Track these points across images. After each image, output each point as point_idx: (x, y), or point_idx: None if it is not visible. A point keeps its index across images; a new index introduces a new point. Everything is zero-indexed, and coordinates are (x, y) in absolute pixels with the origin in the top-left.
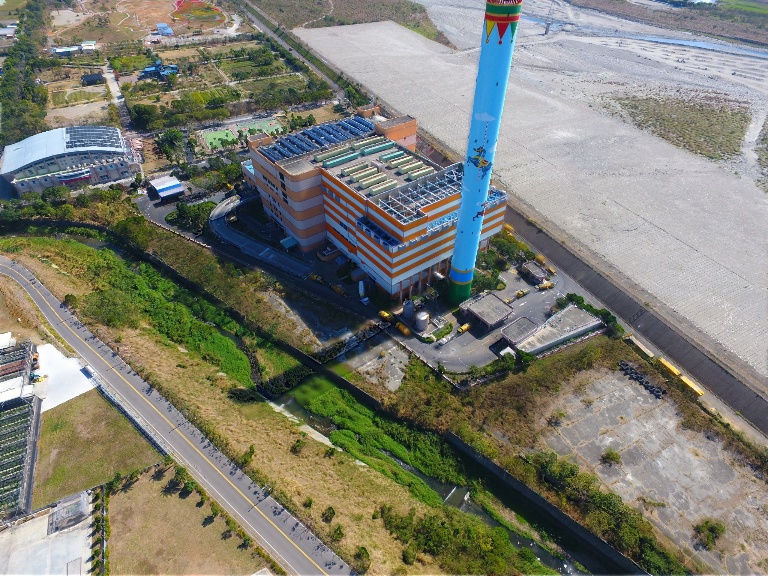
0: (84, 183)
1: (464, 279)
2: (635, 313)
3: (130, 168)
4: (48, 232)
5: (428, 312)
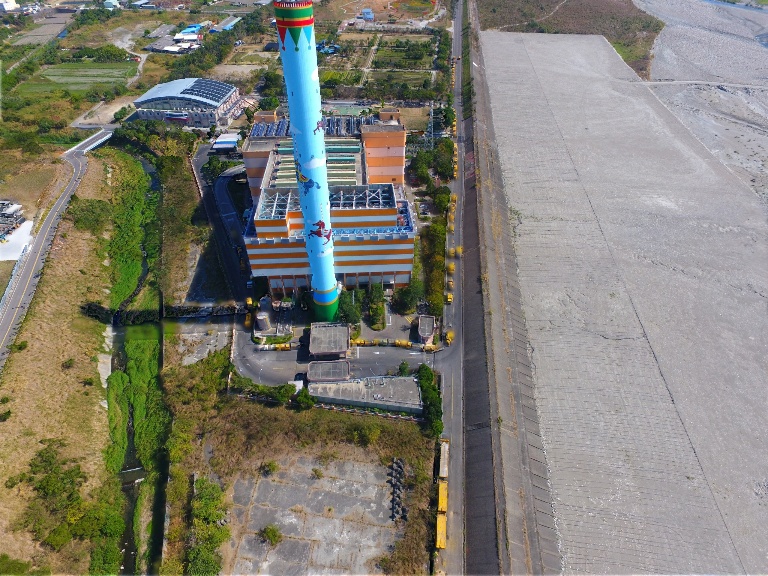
0: (183, 123)
1: (319, 299)
2: (479, 422)
3: (220, 120)
4: (135, 152)
5: (284, 317)
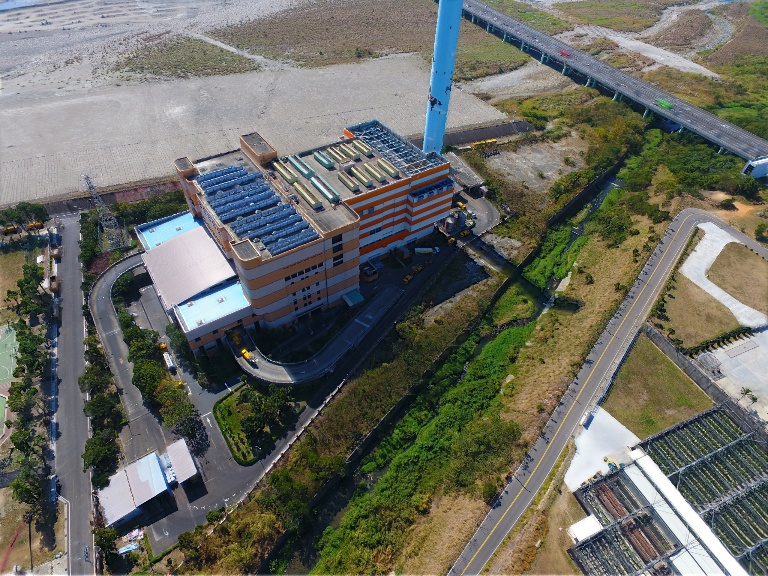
0: None
1: None
2: None
3: None
4: None
5: None
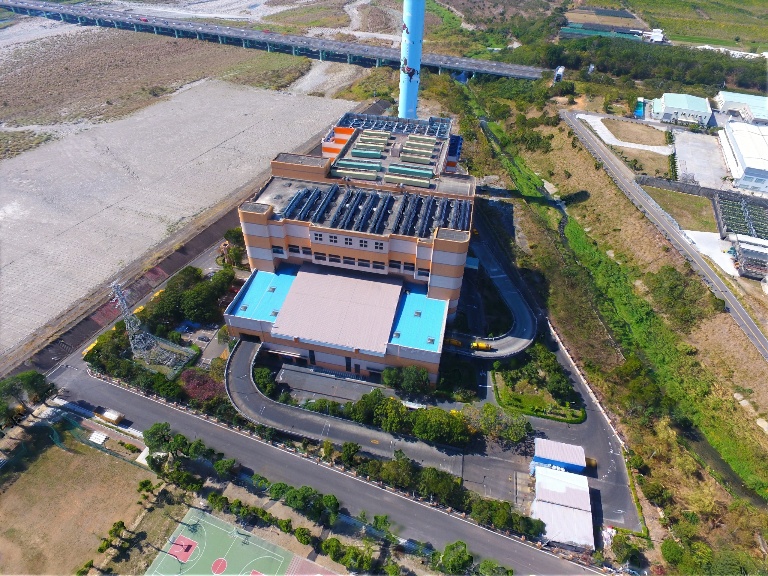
0: None
1: None
2: None
3: None
4: None
5: None
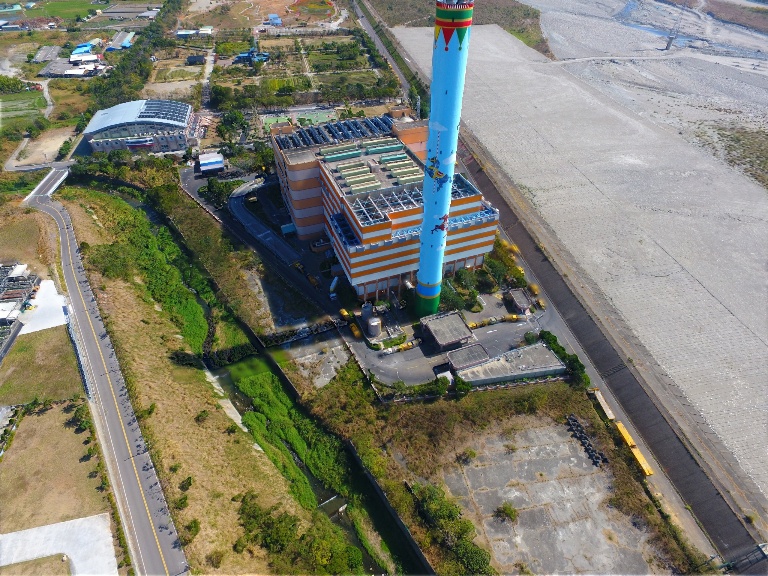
0: (147, 150)
1: (427, 293)
2: (613, 367)
3: (189, 141)
4: (105, 188)
5: (388, 319)
